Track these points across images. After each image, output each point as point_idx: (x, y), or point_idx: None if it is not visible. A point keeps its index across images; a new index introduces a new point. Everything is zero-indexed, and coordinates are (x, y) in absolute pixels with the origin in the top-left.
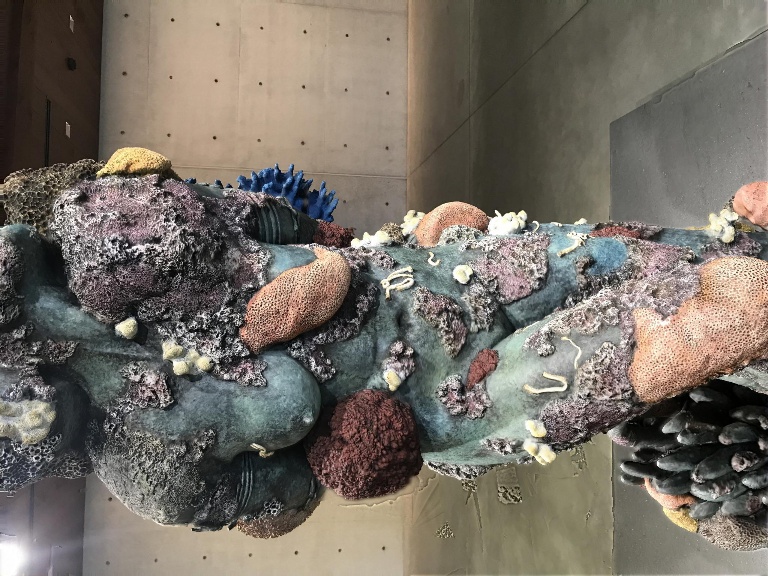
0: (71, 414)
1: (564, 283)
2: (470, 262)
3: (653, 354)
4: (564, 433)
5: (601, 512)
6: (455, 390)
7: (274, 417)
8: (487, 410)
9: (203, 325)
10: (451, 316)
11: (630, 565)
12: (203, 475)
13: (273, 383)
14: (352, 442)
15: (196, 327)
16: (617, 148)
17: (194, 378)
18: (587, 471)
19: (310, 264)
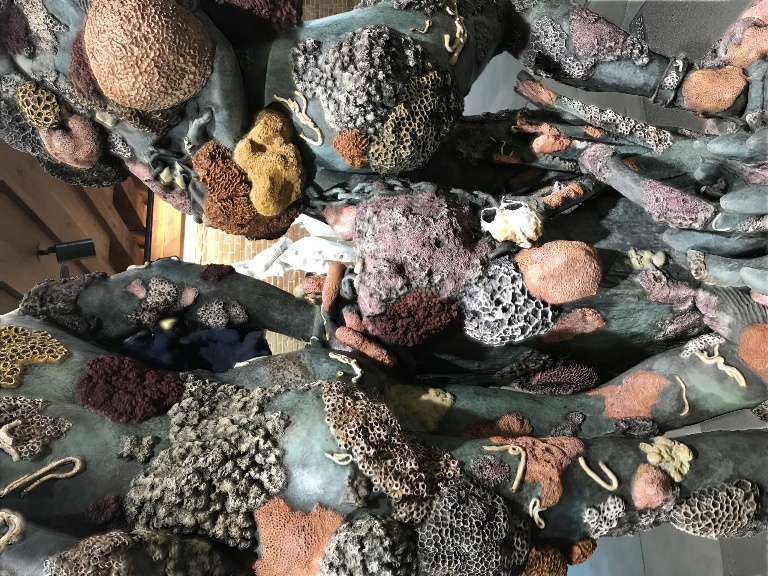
0: None
1: None
2: None
3: None
4: None
5: None
6: None
7: None
8: None
9: None
10: None
11: None
12: None
13: None
14: None
15: None
16: None
17: None
18: None
19: None
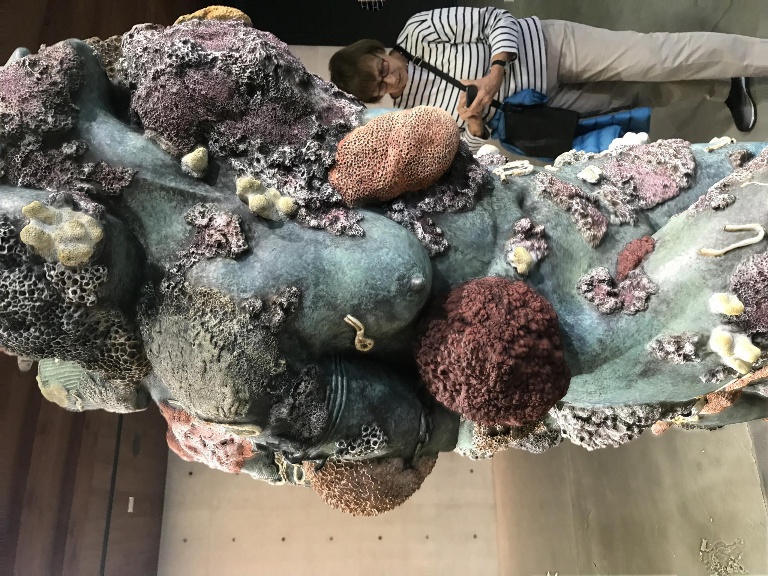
0: (122, 261)
1: (719, 179)
2: None
3: None
4: None
5: None
6: (603, 282)
7: (374, 274)
8: (651, 298)
9: (285, 161)
10: (584, 202)
11: None
12: (283, 354)
13: (372, 234)
14: (477, 321)
15: (277, 161)
16: None
17: (274, 225)
18: None
19: None
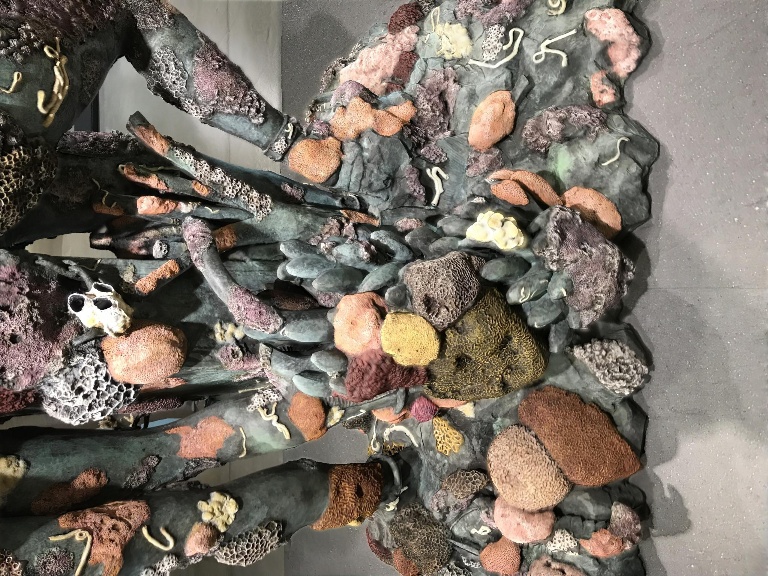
0: None
1: None
2: None
3: None
4: None
5: None
6: None
7: None
8: None
9: None
10: None
11: None
12: None
13: None
14: None
15: None
16: None
17: None
18: None
19: None
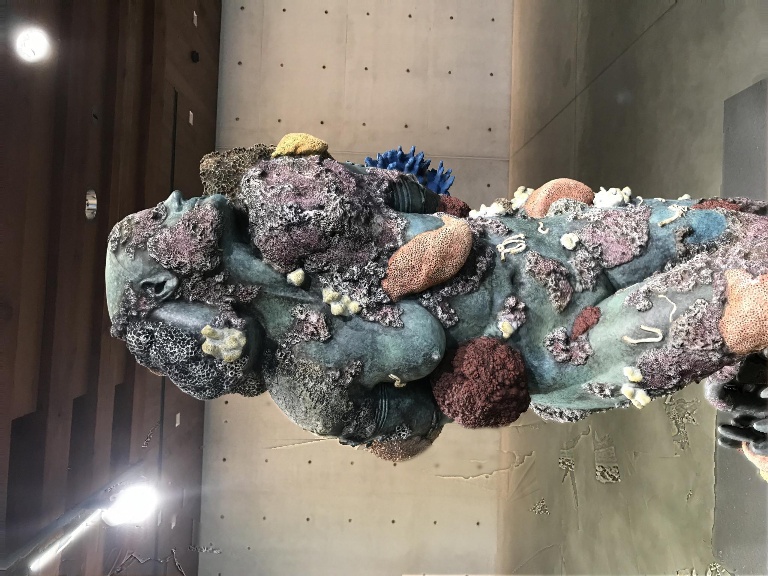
0: (253, 343)
1: (664, 250)
2: (576, 231)
3: (742, 309)
4: (659, 379)
5: (703, 492)
6: (561, 340)
7: (409, 353)
8: (589, 358)
9: (354, 276)
10: (558, 277)
11: (731, 542)
12: (351, 397)
13: (408, 325)
14: (471, 378)
15: (349, 278)
16: (730, 125)
17: (346, 319)
18: (689, 451)
19: (439, 229)
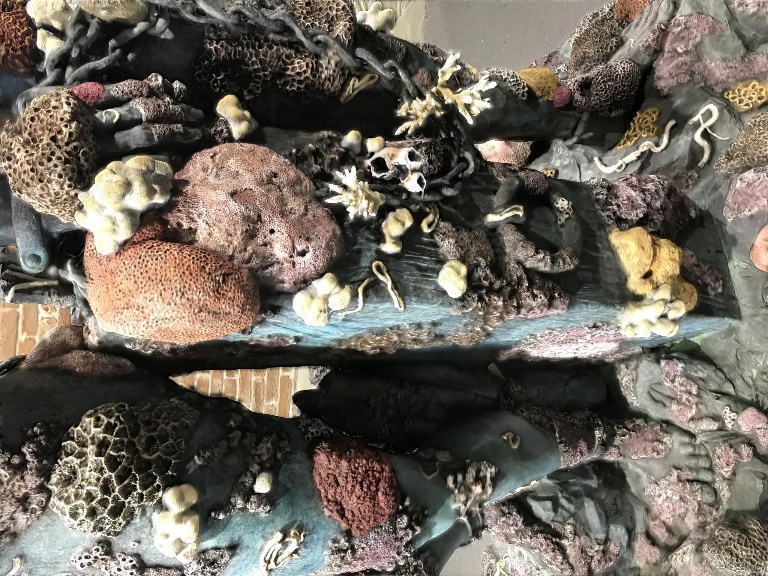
0: None
1: None
2: (79, 575)
3: None
4: None
5: None
6: None
7: None
8: None
9: None
10: None
11: None
12: None
13: None
14: None
15: None
16: None
17: None
18: None
19: None
